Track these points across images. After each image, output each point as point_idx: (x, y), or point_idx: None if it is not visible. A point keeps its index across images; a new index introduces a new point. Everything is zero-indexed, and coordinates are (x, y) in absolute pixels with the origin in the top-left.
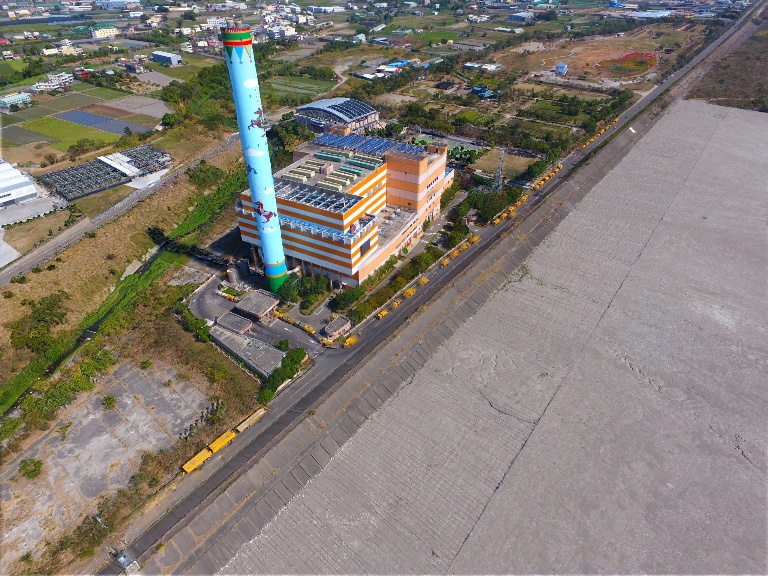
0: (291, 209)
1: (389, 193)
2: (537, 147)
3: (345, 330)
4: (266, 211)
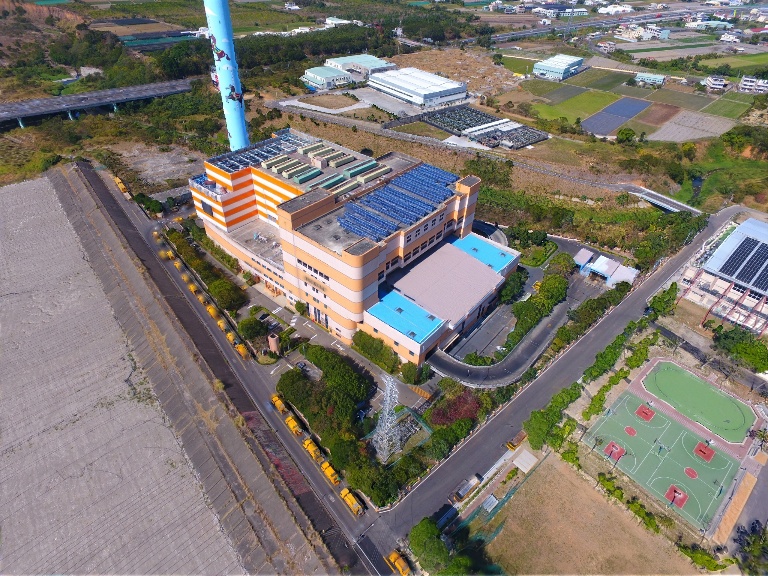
0: None
1: None
2: None
3: None
4: None
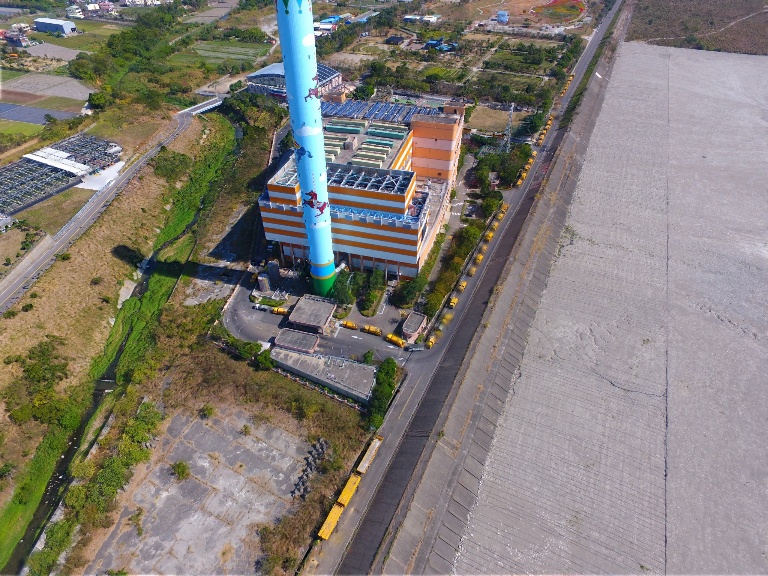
0: (333, 195)
1: (414, 164)
2: (523, 100)
3: (423, 327)
4: (320, 202)
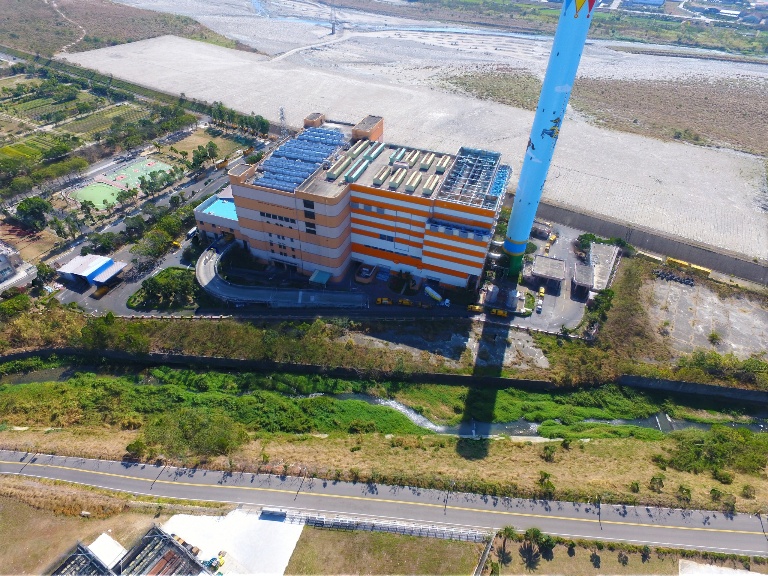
0: None
1: None
2: (189, 120)
3: None
4: None
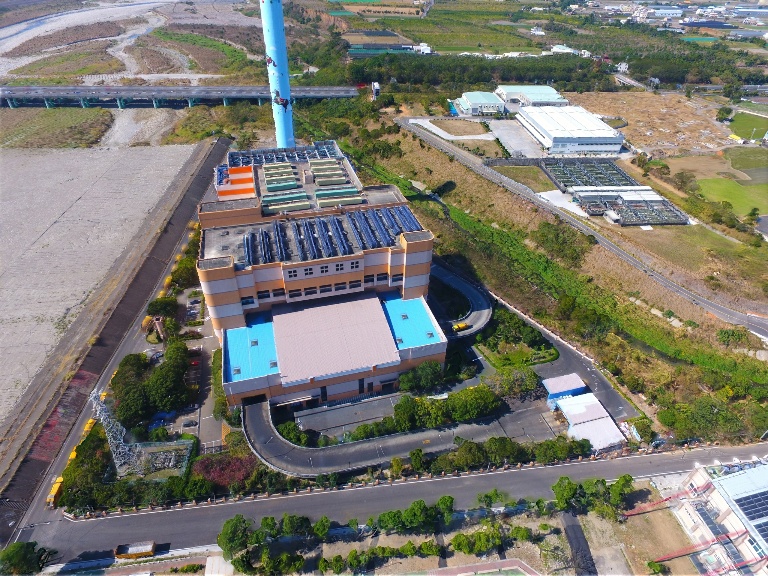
0: None
1: None
2: None
3: None
4: None
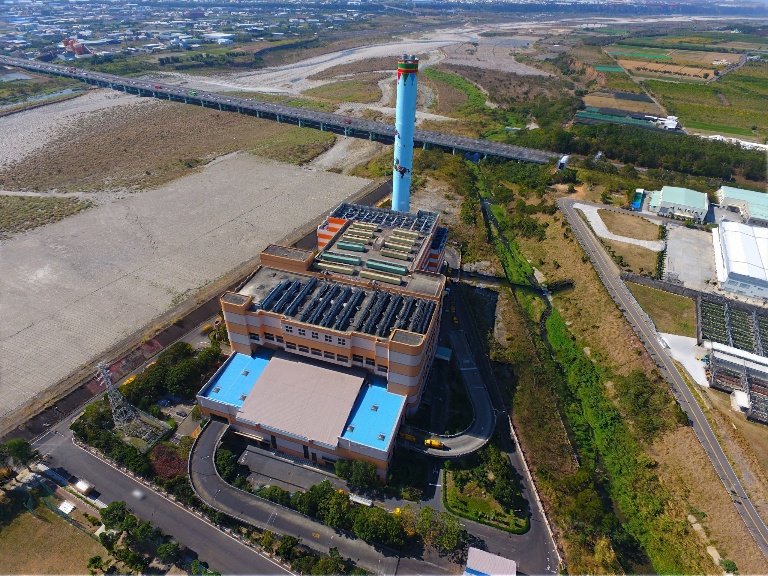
0: None
1: None
2: None
3: None
4: None
